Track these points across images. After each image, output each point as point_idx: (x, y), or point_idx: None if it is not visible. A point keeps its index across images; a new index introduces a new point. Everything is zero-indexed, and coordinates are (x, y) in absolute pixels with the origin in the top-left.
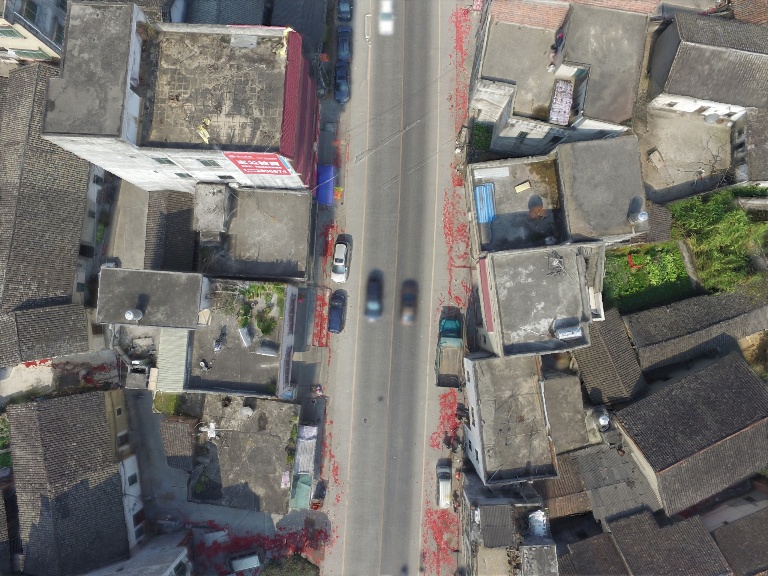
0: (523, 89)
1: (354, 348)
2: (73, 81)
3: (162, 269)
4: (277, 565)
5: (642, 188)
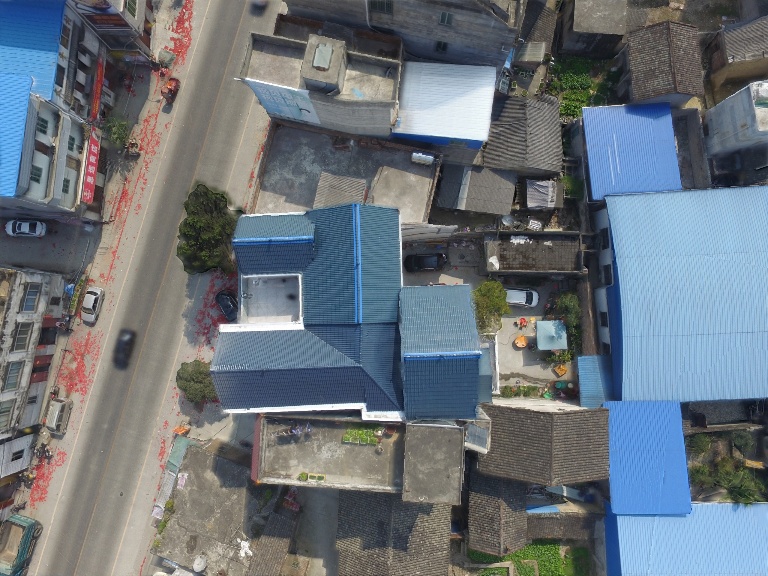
0: None
1: (115, 570)
2: None
3: None
4: None
5: None
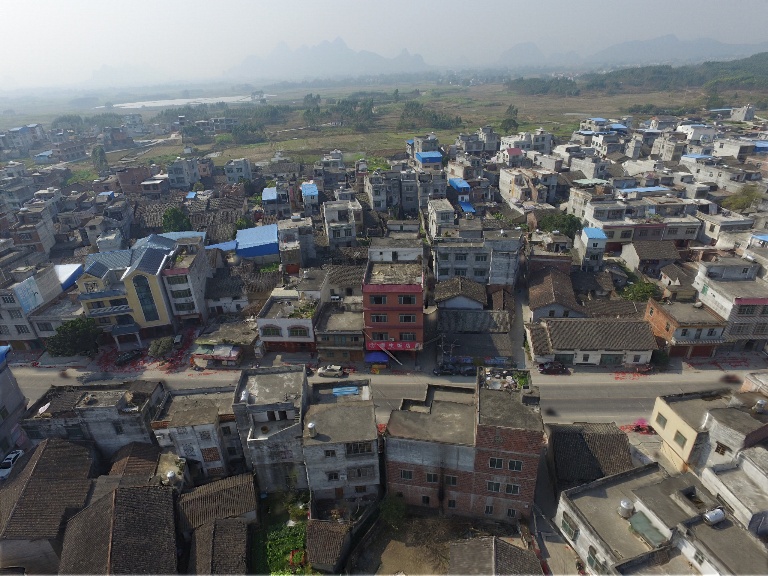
0: (426, 410)
1: None
2: (392, 241)
3: None
4: None
5: (336, 441)
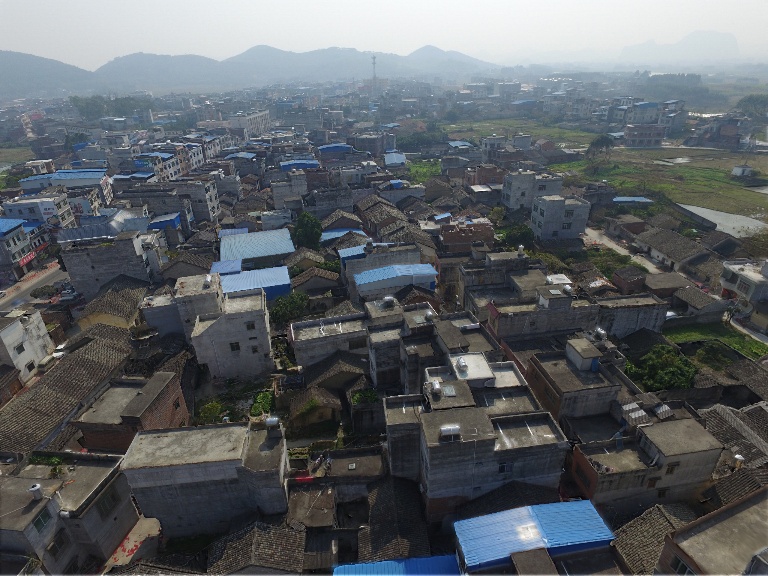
0: None
1: None
2: None
3: (1, 368)
4: (44, 293)
5: None
